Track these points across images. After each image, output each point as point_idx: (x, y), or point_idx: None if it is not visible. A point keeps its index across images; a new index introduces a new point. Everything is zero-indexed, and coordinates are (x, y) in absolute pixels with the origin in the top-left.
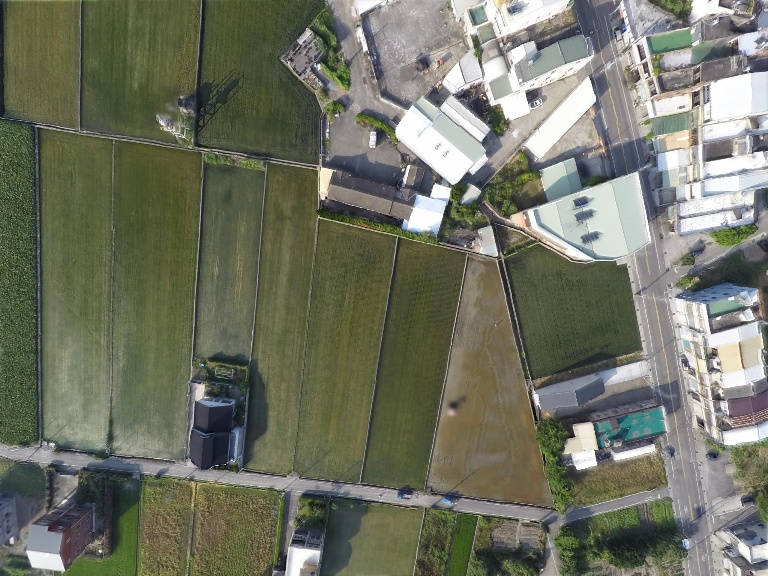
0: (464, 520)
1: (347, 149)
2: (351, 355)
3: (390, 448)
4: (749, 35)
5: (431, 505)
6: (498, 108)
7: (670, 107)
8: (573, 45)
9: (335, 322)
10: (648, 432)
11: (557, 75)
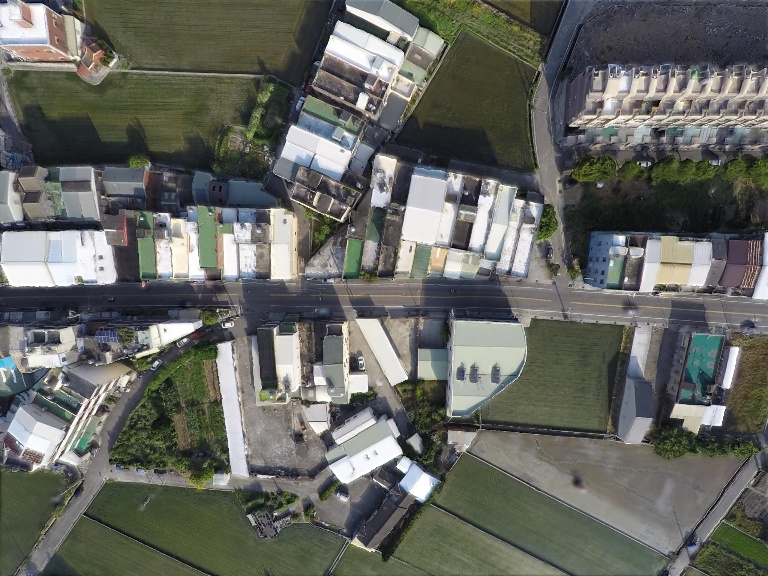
0: (720, 535)
1: (342, 514)
2: (512, 573)
3: (613, 573)
4: (373, 197)
5: (688, 559)
6: (354, 394)
7: (407, 259)
8: (330, 349)
9: (478, 574)
10: (714, 353)
11: (346, 351)
